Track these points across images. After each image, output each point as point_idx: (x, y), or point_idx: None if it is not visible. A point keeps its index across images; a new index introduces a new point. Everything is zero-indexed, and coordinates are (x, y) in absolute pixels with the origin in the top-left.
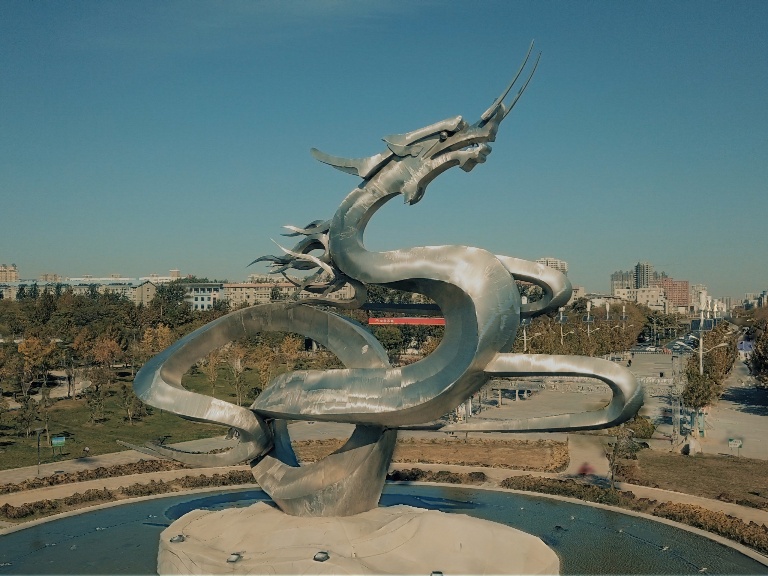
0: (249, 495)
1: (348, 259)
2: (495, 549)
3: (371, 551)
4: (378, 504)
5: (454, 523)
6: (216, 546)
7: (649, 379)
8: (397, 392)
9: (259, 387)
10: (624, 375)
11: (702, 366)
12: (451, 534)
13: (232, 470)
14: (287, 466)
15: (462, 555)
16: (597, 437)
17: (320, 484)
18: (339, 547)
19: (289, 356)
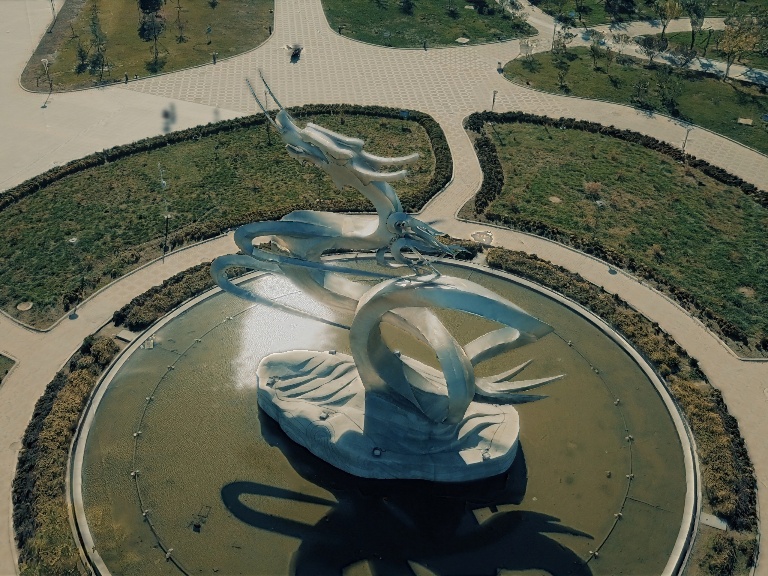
0: None
1: None
2: None
3: None
4: None
5: None
6: None
7: None
8: None
9: None
10: None
11: None
12: None
13: None
14: None
15: None
16: None
17: None
18: None
19: None
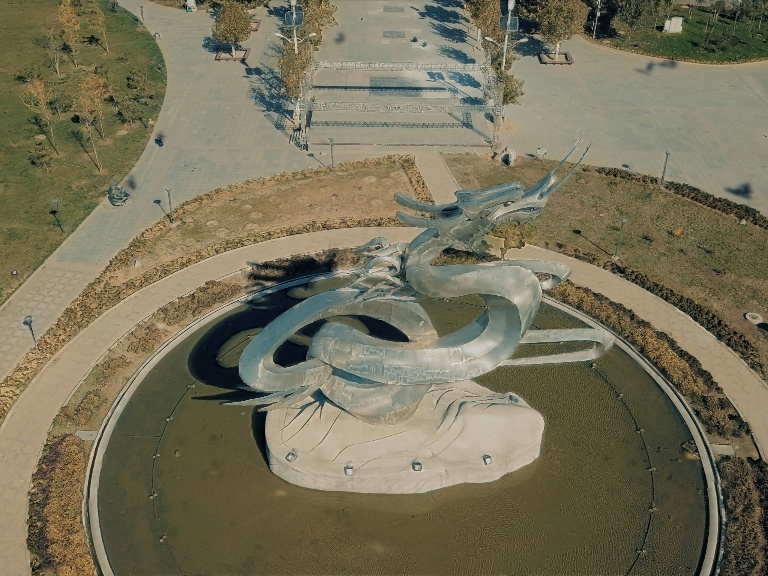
0: (232, 324)
1: (422, 283)
2: (515, 430)
3: (440, 448)
4: (343, 317)
5: (487, 419)
6: (322, 456)
7: (458, 66)
8: (462, 366)
9: (72, 90)
10: (607, 336)
11: (505, 58)
12: (487, 426)
13: (196, 294)
14: (351, 386)
15: (495, 438)
16: (434, 147)
17: (391, 407)
18: (421, 452)
19: (72, 27)
